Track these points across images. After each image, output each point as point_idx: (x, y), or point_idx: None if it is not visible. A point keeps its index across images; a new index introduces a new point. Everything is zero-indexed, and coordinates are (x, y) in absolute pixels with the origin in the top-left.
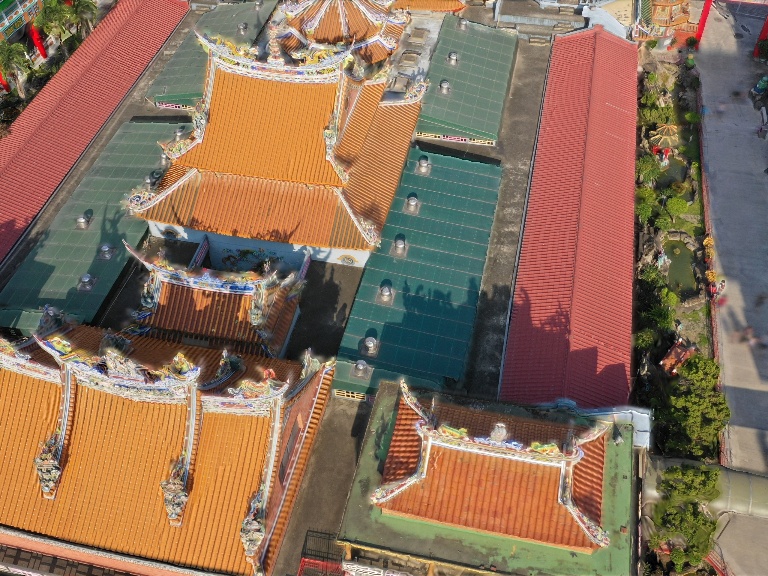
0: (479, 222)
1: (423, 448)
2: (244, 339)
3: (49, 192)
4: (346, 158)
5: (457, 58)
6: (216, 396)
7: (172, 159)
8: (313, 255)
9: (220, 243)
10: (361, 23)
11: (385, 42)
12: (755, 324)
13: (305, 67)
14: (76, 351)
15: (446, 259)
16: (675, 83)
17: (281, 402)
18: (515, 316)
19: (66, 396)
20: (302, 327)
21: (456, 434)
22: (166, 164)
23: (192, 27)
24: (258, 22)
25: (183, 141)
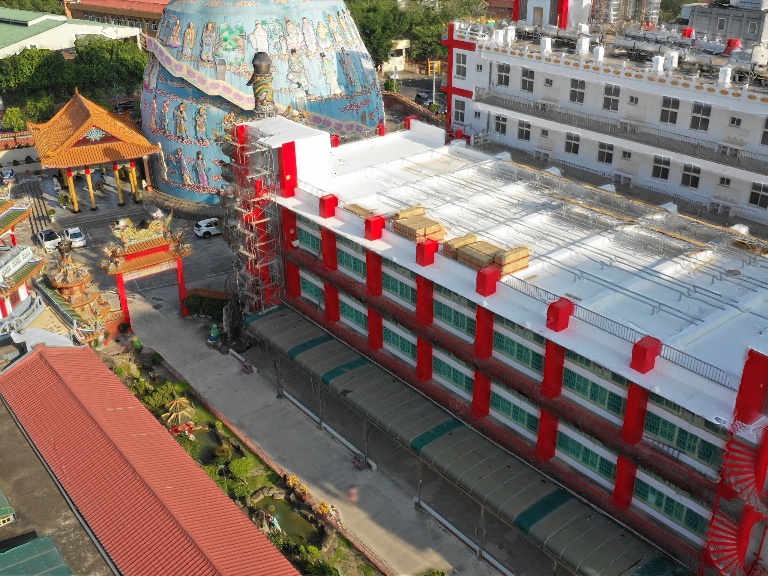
0: None
1: None
2: None
3: None
4: None
5: None
6: None
7: None
8: None
9: None
10: None
11: None
12: (389, 524)
13: None
14: None
15: None
16: (138, 368)
17: None
18: None
19: None
20: None
21: None
22: None
23: None
24: None
25: None
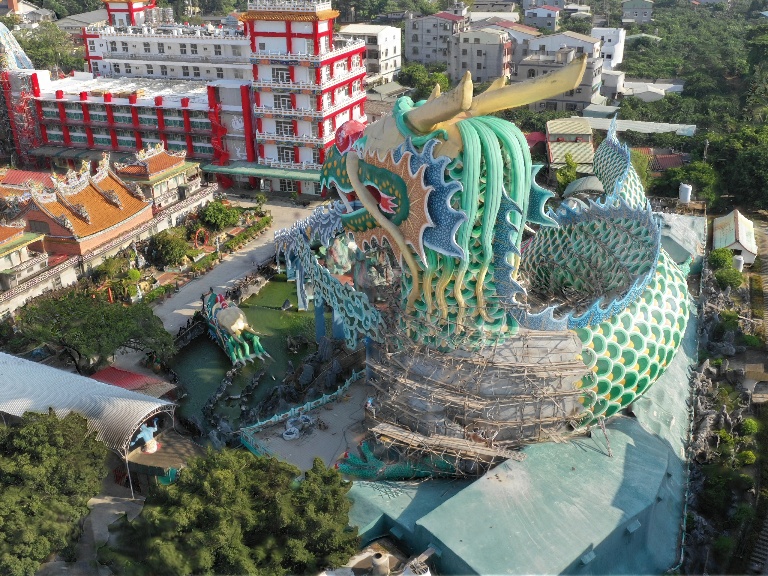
0: None
1: (141, 161)
2: None
3: None
4: None
5: None
6: None
7: None
8: None
9: None
10: None
11: None
12: None
13: None
14: None
15: None
16: None
17: None
18: None
19: None
20: None
21: None
22: None
23: None
24: None
25: None
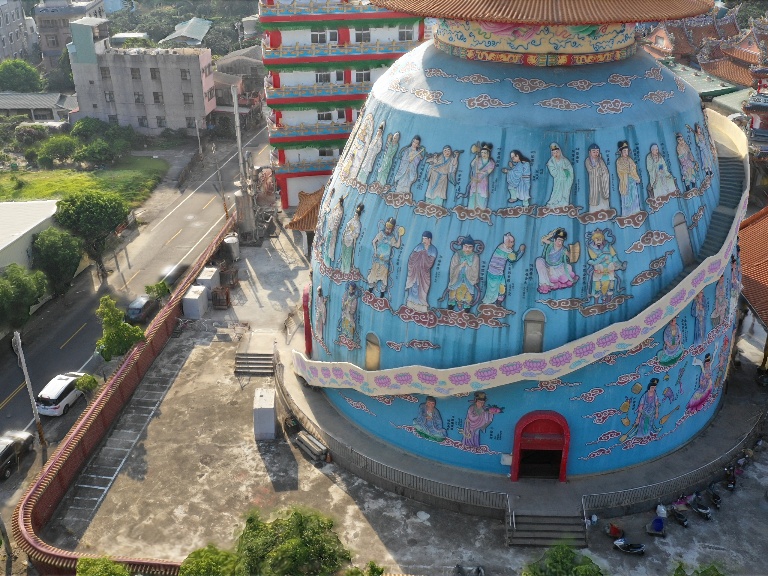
0: None
1: None
2: None
3: None
4: None
5: None
6: None
7: None
8: None
9: None
10: None
11: None
12: None
13: None
14: None
15: None
16: None
17: None
18: None
19: None
20: None
21: None
22: None
23: None
24: None
25: None
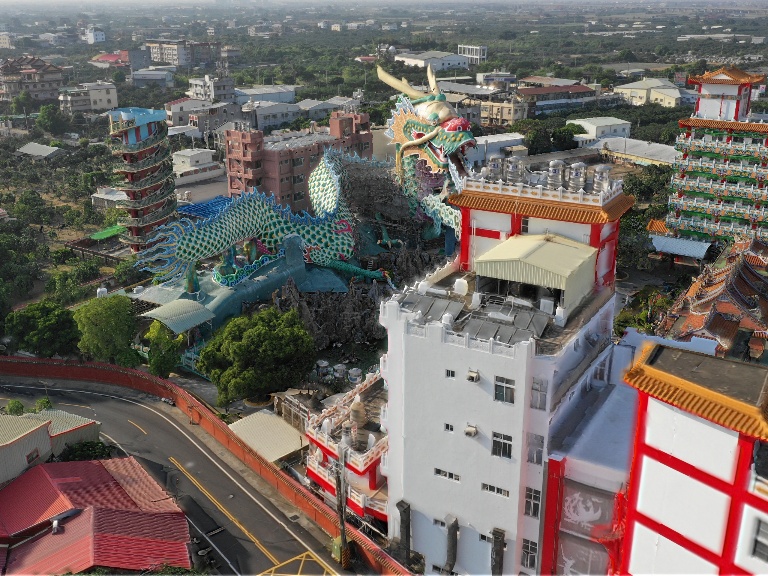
0: None
1: None
2: None
3: None
4: None
5: None
6: None
7: None
8: None
9: None
10: None
11: None
12: None
13: None
14: None
15: None
16: None
17: (725, 287)
18: None
19: None
20: None
21: None
22: None
23: None
24: None
25: None
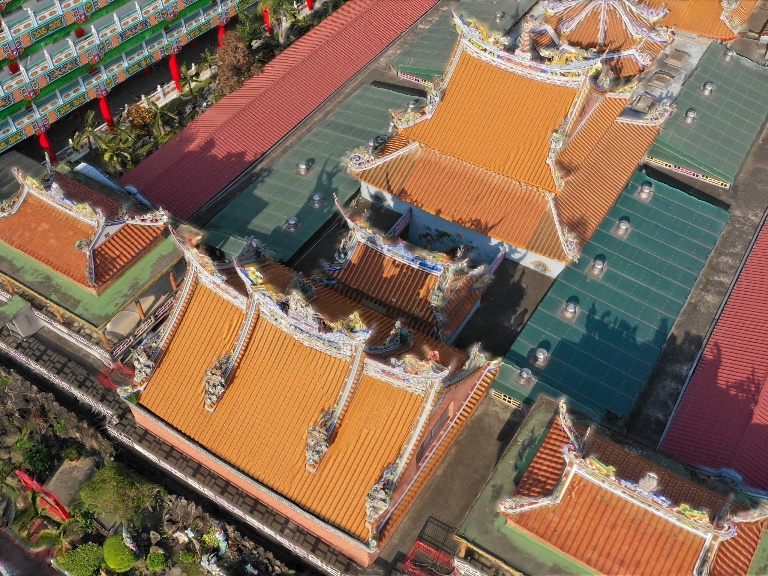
0: (688, 263)
1: (565, 473)
2: (419, 316)
3: (281, 134)
4: (567, 165)
5: (712, 89)
6: (379, 362)
7: (399, 128)
8: (508, 253)
9: (422, 219)
10: (620, 33)
11: (640, 57)
12: None
13: (550, 66)
14: (266, 285)
15: (642, 292)
16: None
17: (438, 386)
18: (700, 369)
19: (247, 323)
20: (478, 320)
21: (603, 470)
22: (392, 132)
23: (451, 6)
24: (516, 13)
25: (413, 113)
